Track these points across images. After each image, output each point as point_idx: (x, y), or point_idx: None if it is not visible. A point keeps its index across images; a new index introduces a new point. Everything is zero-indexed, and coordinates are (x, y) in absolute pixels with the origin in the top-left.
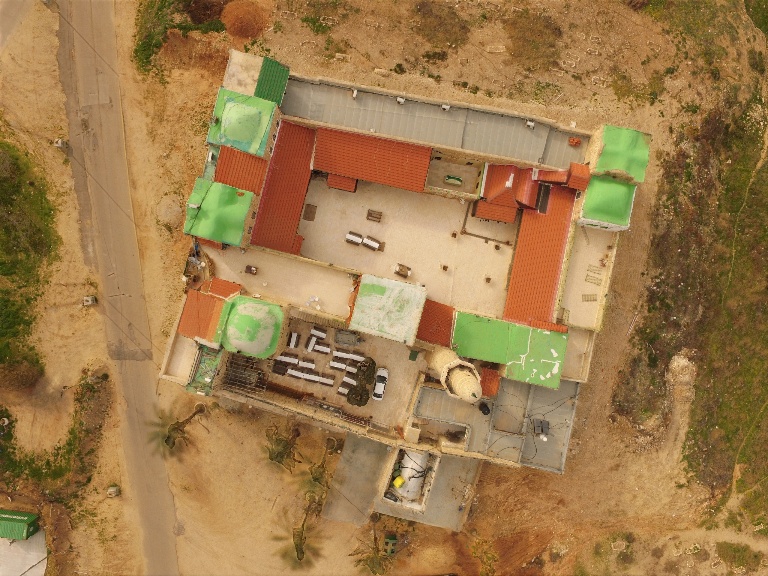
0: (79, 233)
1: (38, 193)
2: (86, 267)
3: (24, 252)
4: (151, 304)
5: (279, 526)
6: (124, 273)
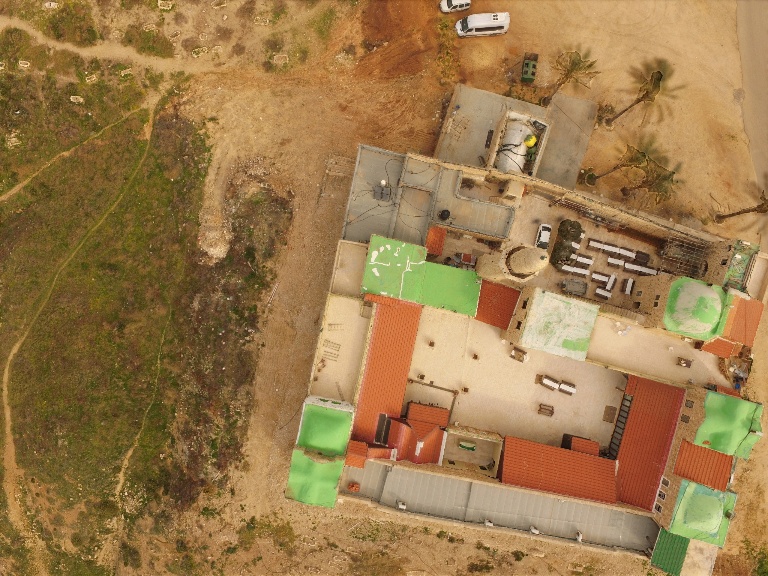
0: None
1: None
2: None
3: None
4: (766, 325)
5: None
6: None
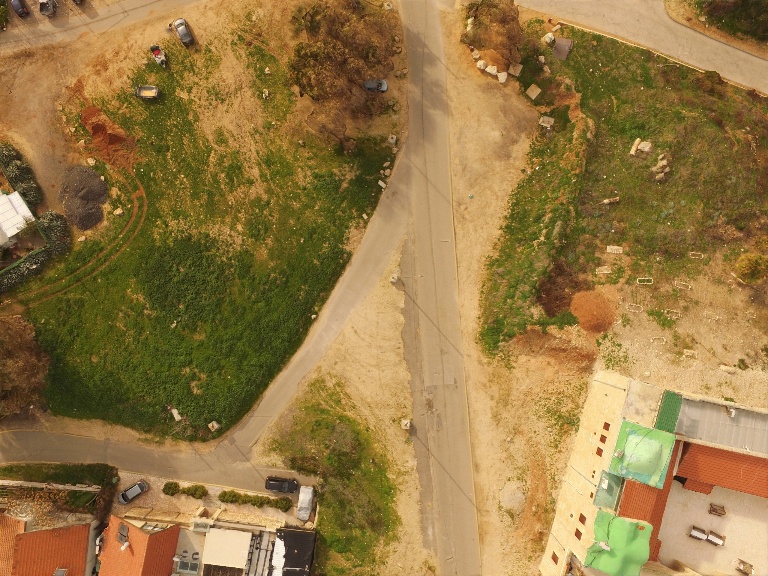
0: (419, 514)
1: (378, 470)
2: (425, 550)
3: (359, 529)
4: None
5: None
6: (463, 558)
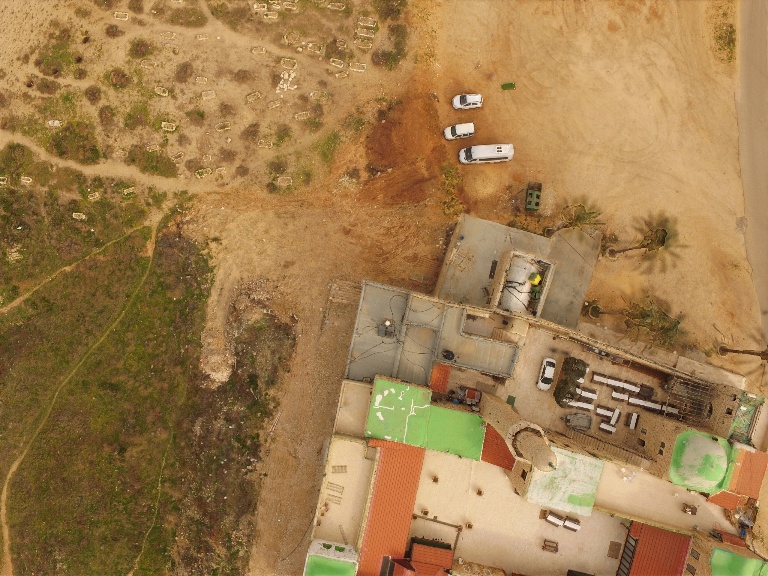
0: None
1: None
2: None
3: None
4: None
5: (642, 223)
6: None
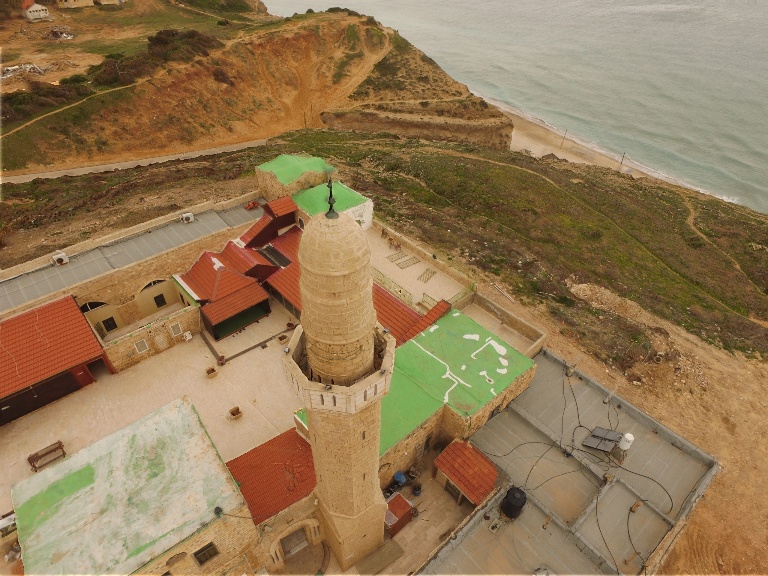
0: None
1: None
2: None
3: None
4: None
5: None
6: None
